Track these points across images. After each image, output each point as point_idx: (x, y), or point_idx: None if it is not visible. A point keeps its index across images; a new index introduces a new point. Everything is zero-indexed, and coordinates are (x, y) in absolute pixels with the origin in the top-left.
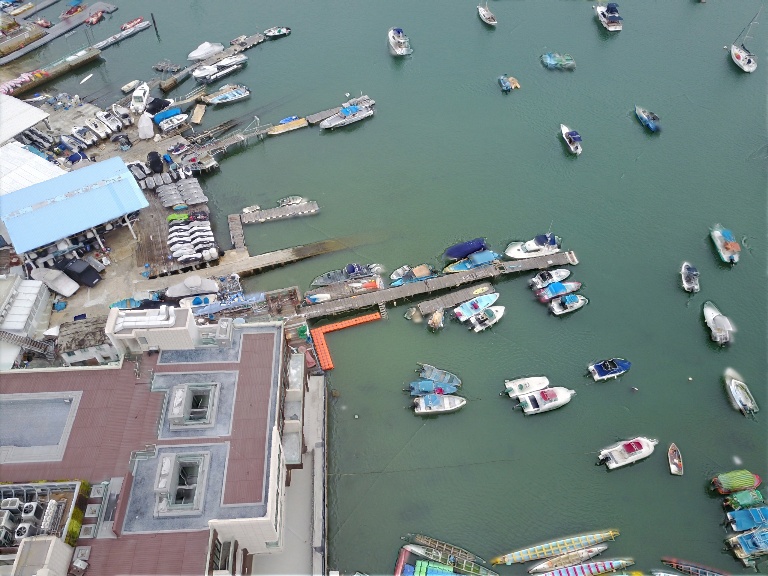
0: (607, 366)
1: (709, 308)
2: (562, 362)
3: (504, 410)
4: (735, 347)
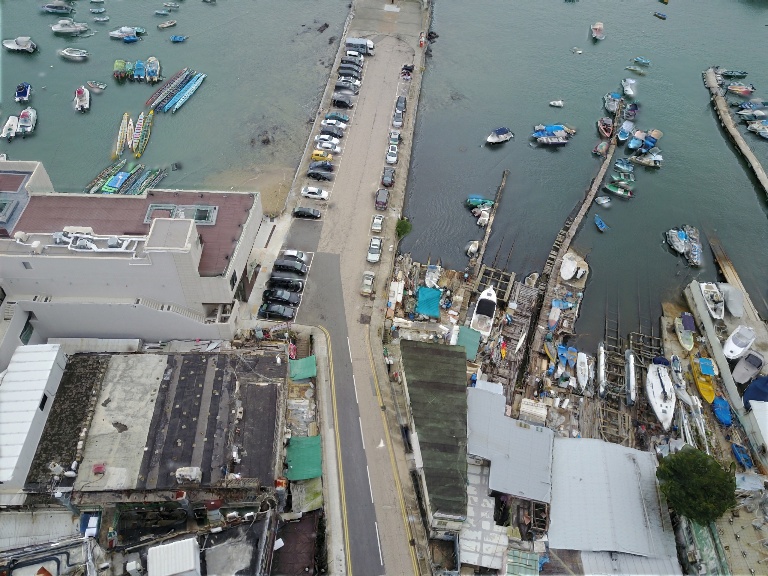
0: (21, 89)
1: (8, 44)
2: (3, 113)
3: (22, 143)
4: (42, 46)
